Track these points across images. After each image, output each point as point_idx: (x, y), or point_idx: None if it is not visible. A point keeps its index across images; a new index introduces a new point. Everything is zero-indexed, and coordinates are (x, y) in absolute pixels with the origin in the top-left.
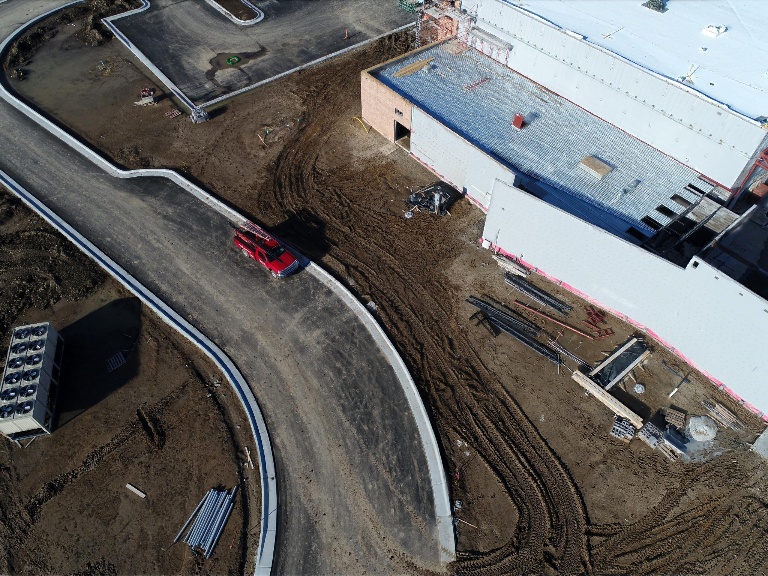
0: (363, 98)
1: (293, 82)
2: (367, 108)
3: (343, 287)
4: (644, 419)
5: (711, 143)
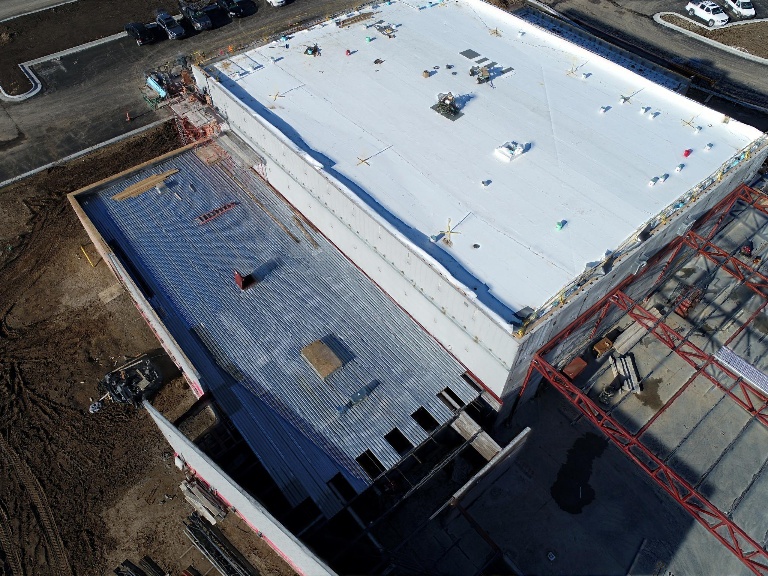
0: None
1: (33, 186)
2: (90, 236)
3: None
4: None
5: (467, 337)
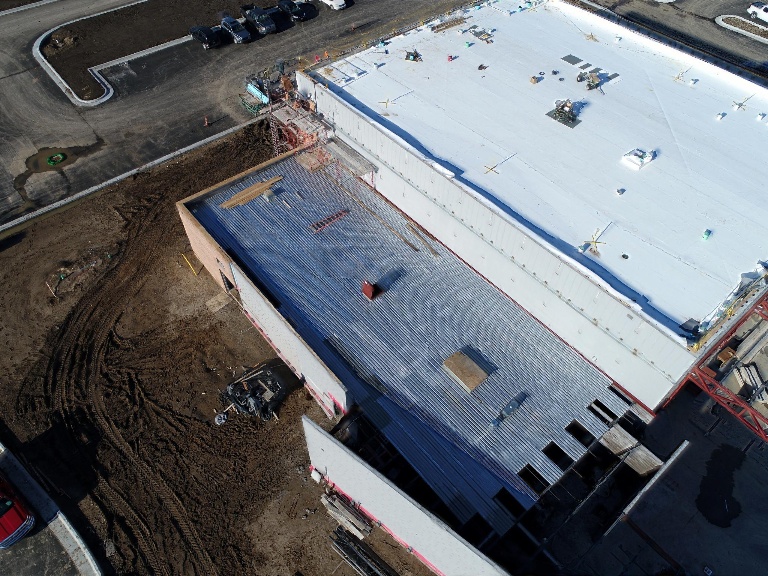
0: (187, 232)
1: (122, 193)
2: (194, 244)
3: (93, 563)
4: None
5: (622, 349)
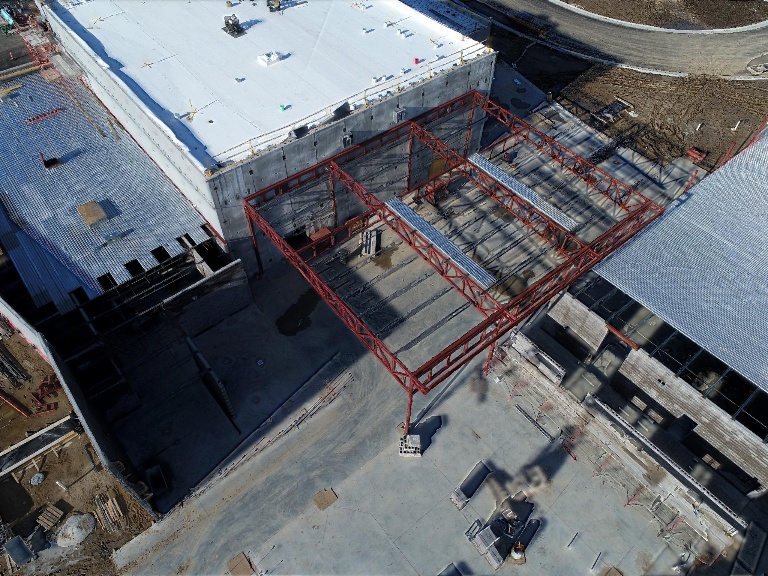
0: None
1: None
2: None
3: None
4: (16, 518)
5: None
